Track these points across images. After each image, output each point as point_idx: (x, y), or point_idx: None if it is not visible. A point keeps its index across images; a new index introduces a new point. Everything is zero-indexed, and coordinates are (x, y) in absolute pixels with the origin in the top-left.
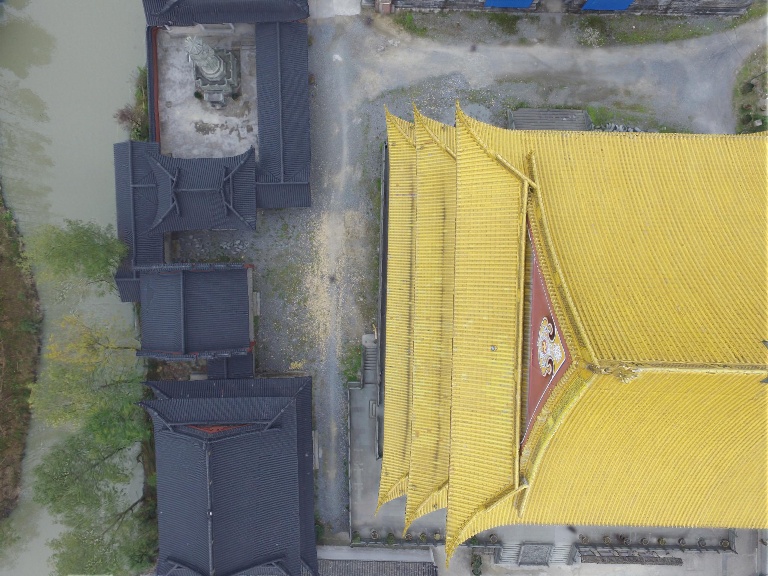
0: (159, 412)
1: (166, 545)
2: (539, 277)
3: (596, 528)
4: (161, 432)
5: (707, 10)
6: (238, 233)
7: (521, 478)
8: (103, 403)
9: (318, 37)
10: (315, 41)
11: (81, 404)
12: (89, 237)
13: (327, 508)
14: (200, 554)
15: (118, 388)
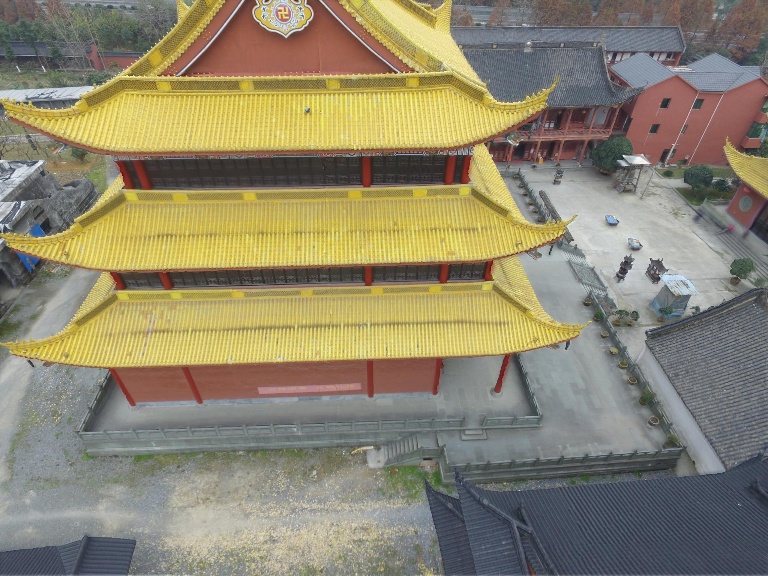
0: None
1: None
2: (223, 58)
3: None
4: None
5: (84, 206)
6: None
7: None
8: None
9: None
10: None
11: None
12: None
13: None
14: None
15: None
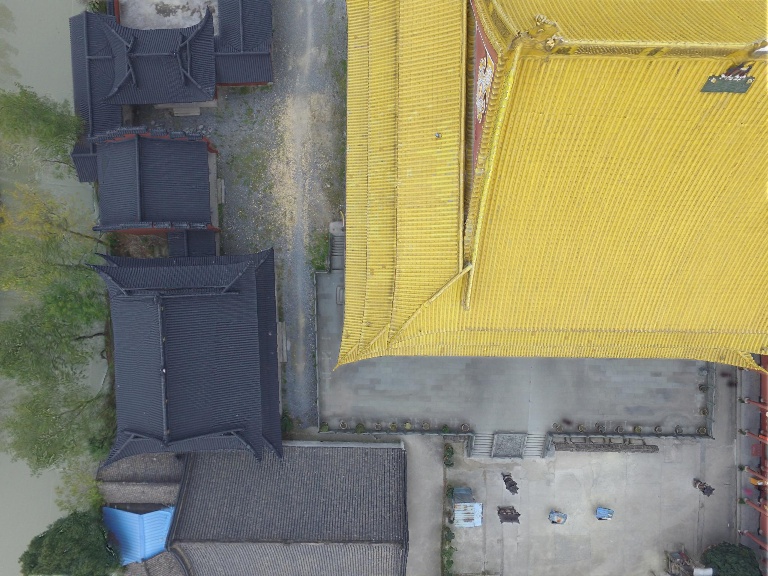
0: (113, 278)
1: (123, 418)
2: (480, 39)
3: (570, 417)
4: (115, 297)
5: None
6: (201, 118)
7: (465, 262)
8: (57, 273)
9: None
10: None
11: (32, 269)
12: (44, 110)
13: (296, 402)
14: (155, 417)
15: (77, 271)
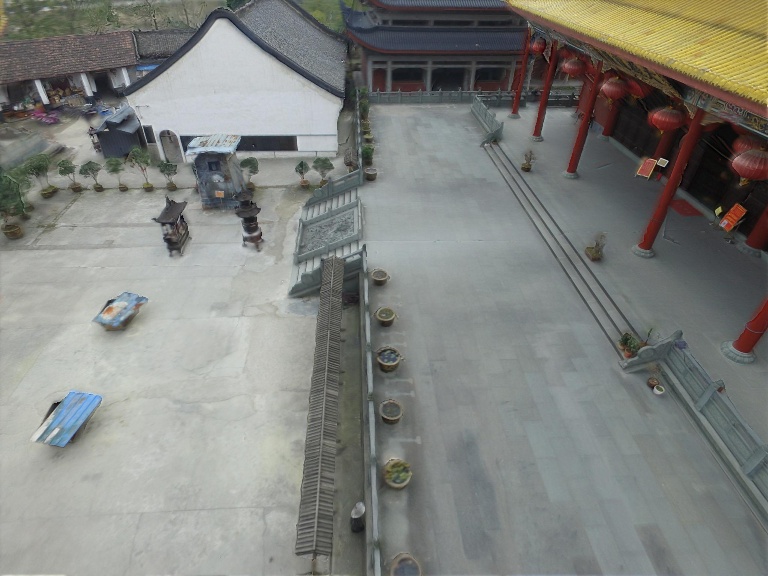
0: None
1: None
2: None
3: (412, 303)
4: None
5: None
6: None
7: None
8: None
9: None
10: None
11: None
12: None
13: None
14: None
15: None
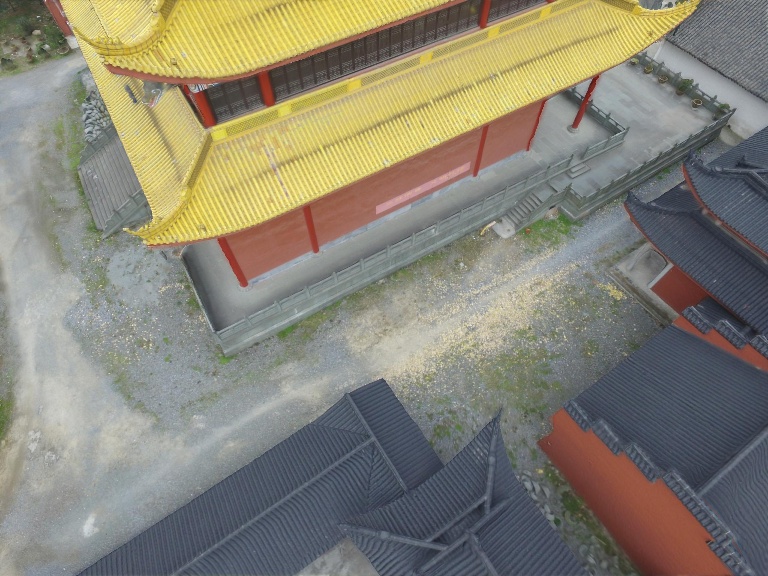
0: None
1: None
2: None
3: None
4: None
5: None
6: None
7: None
8: None
9: None
10: None
11: None
12: None
13: None
14: None
15: None
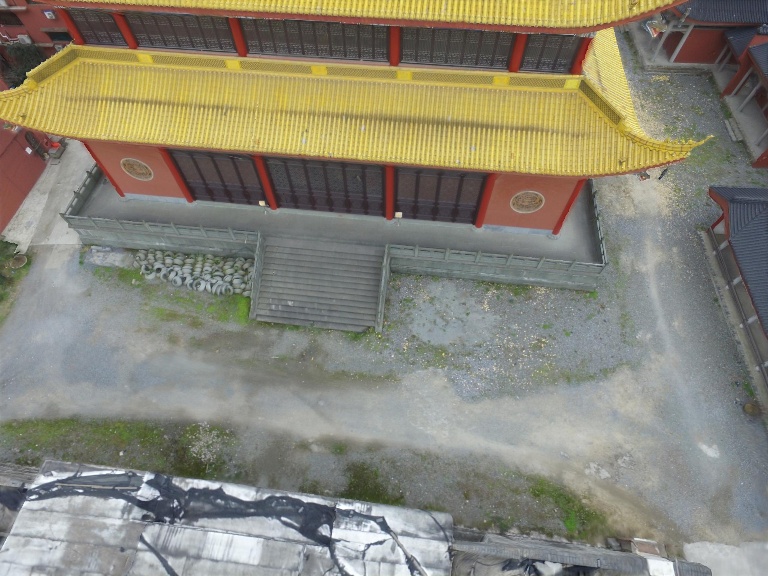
0: None
1: None
2: None
3: None
4: None
5: None
6: None
7: None
8: None
9: (763, 499)
10: (767, 491)
11: None
12: None
13: None
14: None
15: None
